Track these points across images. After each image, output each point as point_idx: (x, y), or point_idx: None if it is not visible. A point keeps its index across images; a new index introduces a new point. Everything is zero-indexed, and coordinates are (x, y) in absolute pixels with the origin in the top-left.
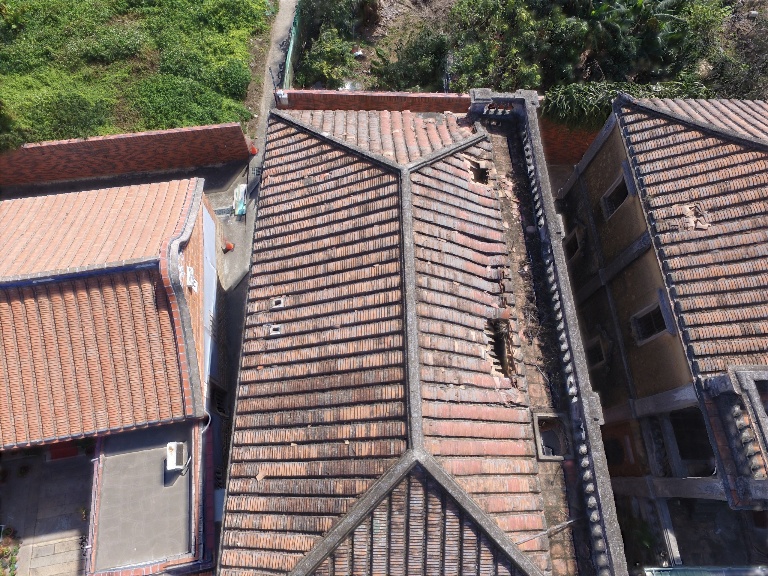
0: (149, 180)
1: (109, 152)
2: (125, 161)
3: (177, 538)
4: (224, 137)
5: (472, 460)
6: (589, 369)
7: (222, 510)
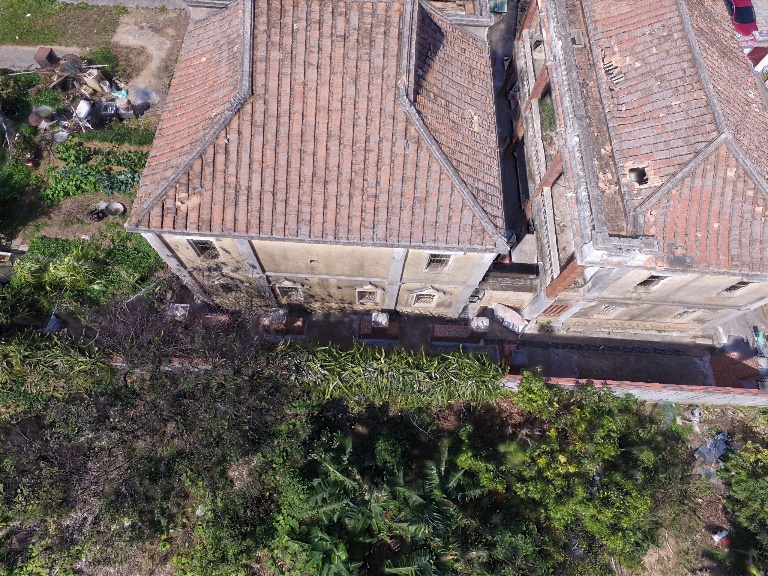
0: None
1: None
2: None
3: None
4: None
5: (638, 7)
6: None
7: None
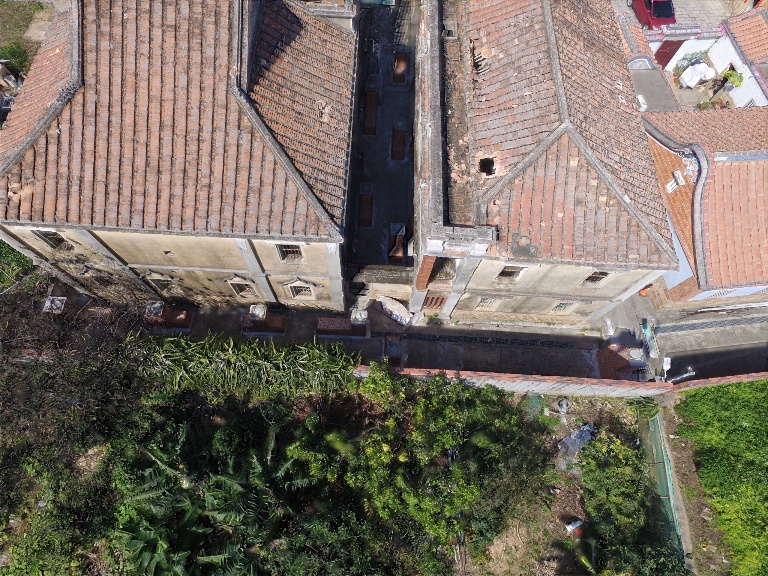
0: (749, 369)
1: None
2: None
3: None
4: None
5: None
6: (351, 162)
7: None
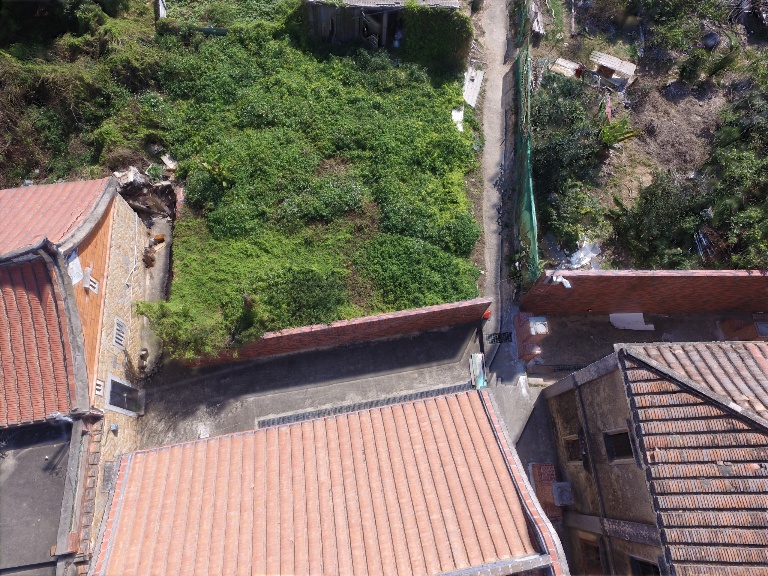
0: (372, 350)
1: (345, 331)
2: (354, 335)
3: None
4: (468, 310)
5: None
6: None
7: None
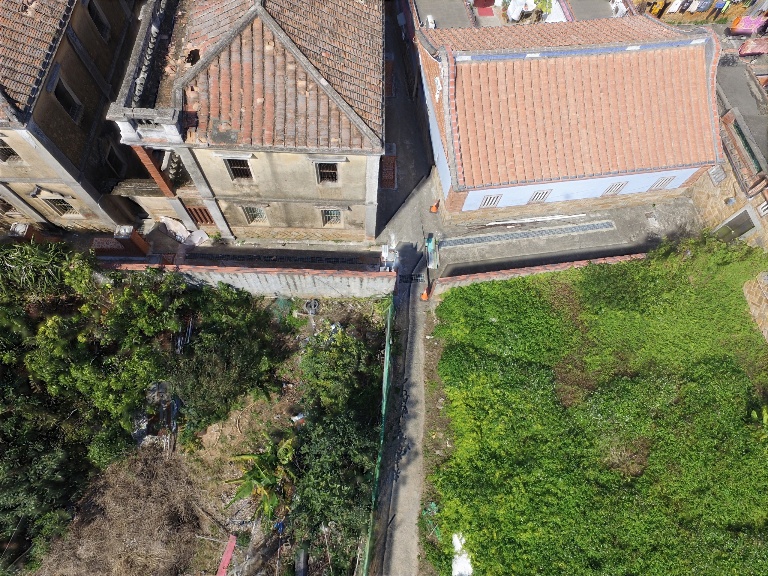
0: None
1: None
2: None
3: (422, 2)
4: None
5: None
6: None
7: (401, 17)
